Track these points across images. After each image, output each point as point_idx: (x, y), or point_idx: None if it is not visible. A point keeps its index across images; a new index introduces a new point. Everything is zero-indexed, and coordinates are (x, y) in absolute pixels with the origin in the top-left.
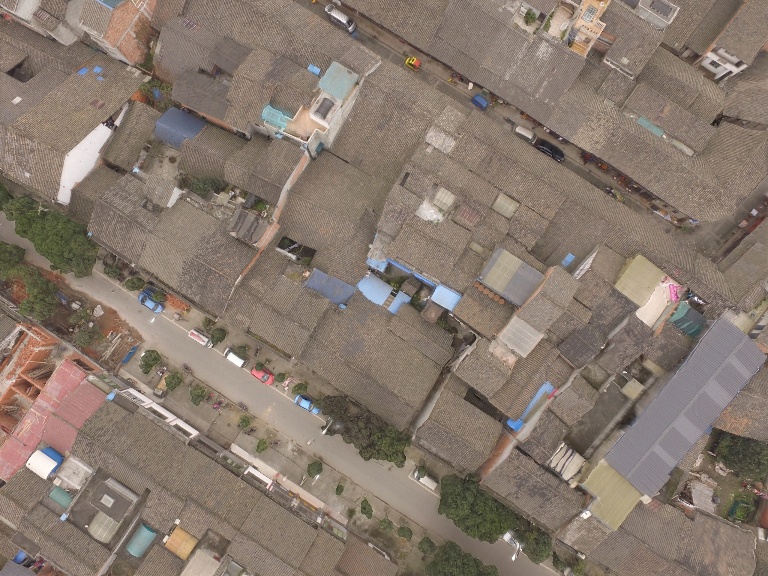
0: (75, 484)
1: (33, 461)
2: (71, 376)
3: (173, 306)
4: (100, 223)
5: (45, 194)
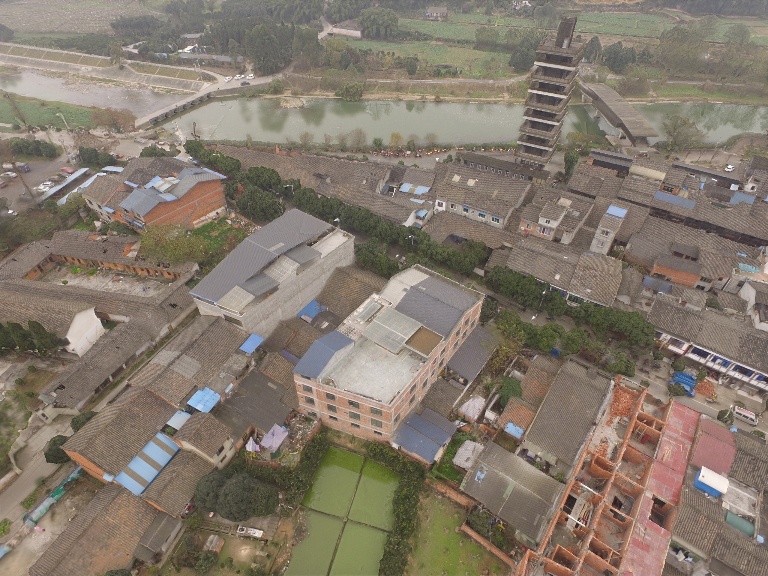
0: (744, 510)
1: (706, 473)
2: (686, 414)
3: (701, 393)
4: (658, 315)
5: (602, 302)
